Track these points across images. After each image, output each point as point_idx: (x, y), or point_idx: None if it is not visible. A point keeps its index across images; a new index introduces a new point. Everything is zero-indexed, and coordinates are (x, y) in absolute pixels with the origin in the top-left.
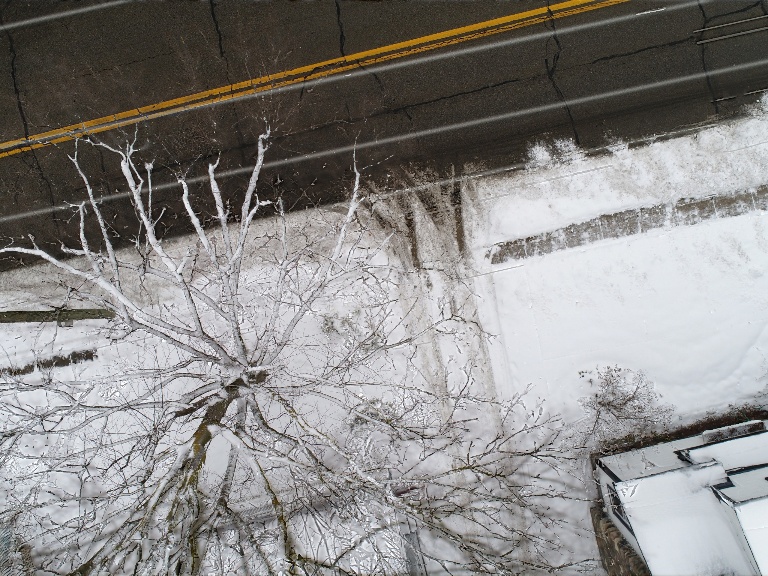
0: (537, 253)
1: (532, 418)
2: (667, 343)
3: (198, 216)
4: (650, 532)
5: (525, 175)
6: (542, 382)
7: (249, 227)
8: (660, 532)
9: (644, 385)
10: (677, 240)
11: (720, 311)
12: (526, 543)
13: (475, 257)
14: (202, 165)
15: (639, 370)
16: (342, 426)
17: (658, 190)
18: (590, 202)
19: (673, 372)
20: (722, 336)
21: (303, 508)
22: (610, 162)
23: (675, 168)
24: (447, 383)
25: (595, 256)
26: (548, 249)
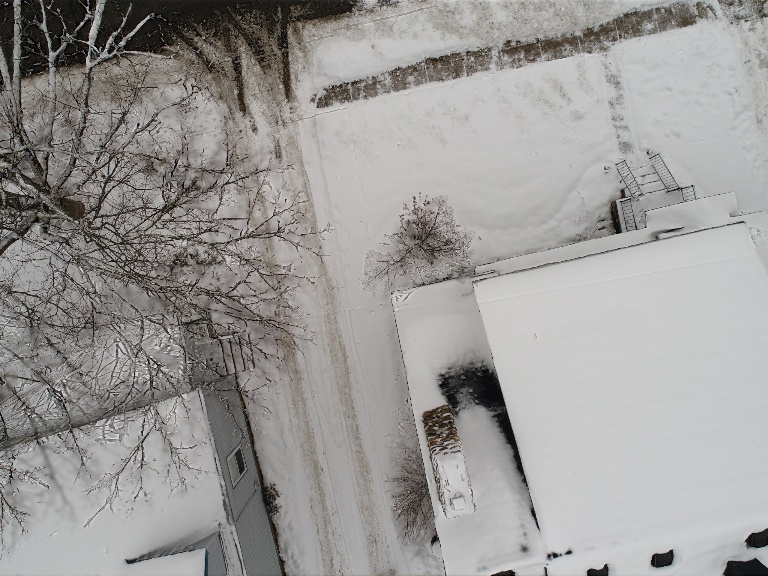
0: (362, 97)
1: (352, 262)
2: (488, 186)
3: (26, 60)
4: (410, 328)
5: (351, 17)
6: (363, 225)
7: (77, 71)
8: (419, 327)
9: (444, 211)
10: (500, 81)
11: (541, 154)
12: (348, 391)
13: (300, 100)
14: (30, 7)
15: (439, 196)
16: (163, 269)
17: (481, 30)
18: (413, 42)
19: (493, 215)
20: (543, 179)
21: (56, 295)
22: (435, 3)
23: (498, 8)
24: (270, 228)
25: (418, 98)
26: (373, 93)
